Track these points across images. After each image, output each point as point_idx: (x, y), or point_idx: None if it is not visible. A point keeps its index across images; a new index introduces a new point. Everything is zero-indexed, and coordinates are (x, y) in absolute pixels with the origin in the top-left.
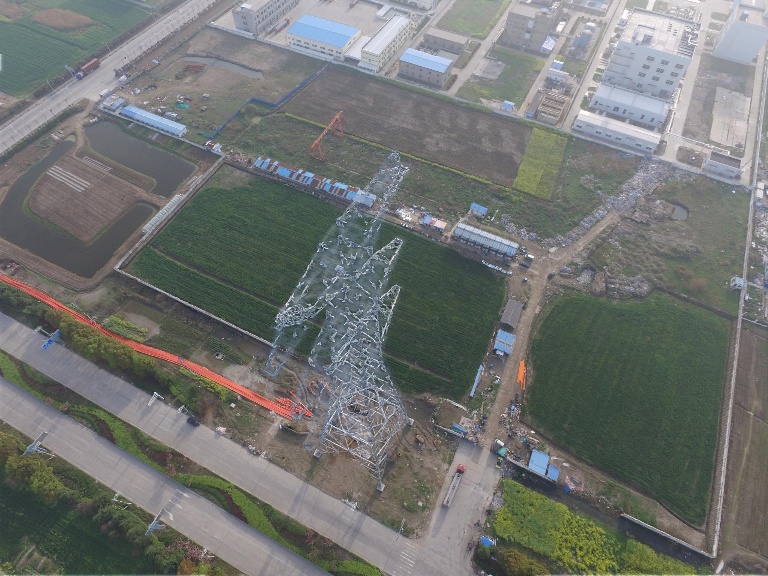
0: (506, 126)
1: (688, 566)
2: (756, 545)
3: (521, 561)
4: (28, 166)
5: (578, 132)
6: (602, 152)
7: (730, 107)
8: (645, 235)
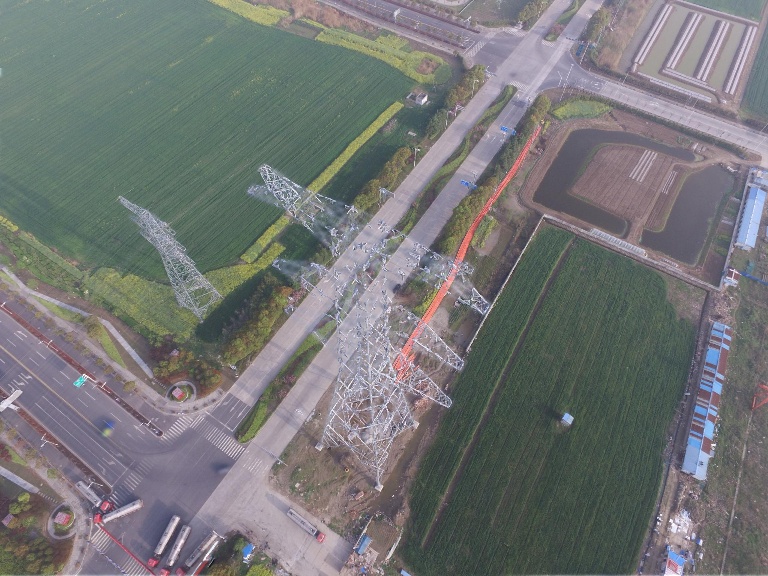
0: None
1: None
2: None
3: None
4: (651, 136)
5: None
6: None
7: None
8: None
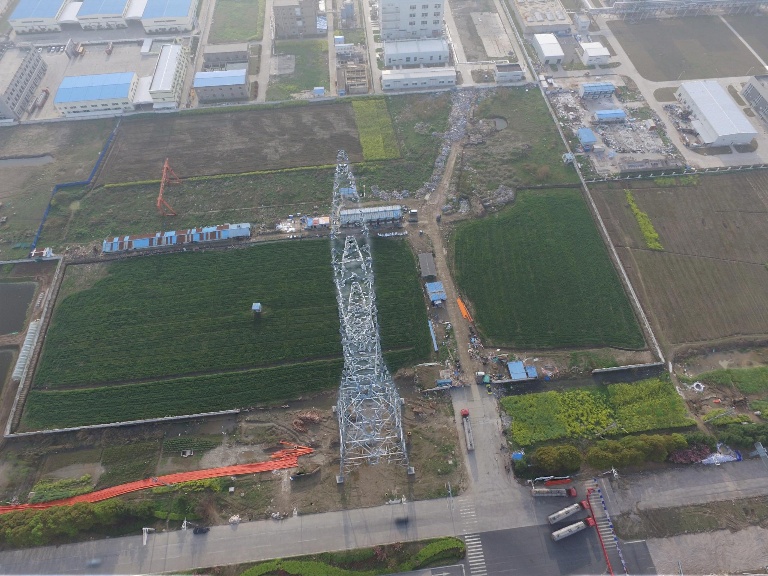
0: (327, 110)
1: (653, 379)
2: (681, 337)
3: (551, 452)
4: None
5: (389, 91)
6: (418, 99)
7: (488, 26)
8: (487, 152)
